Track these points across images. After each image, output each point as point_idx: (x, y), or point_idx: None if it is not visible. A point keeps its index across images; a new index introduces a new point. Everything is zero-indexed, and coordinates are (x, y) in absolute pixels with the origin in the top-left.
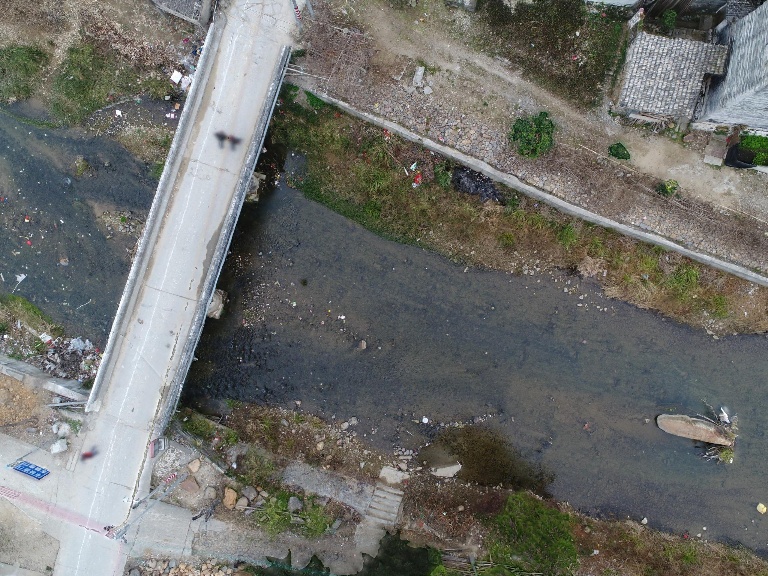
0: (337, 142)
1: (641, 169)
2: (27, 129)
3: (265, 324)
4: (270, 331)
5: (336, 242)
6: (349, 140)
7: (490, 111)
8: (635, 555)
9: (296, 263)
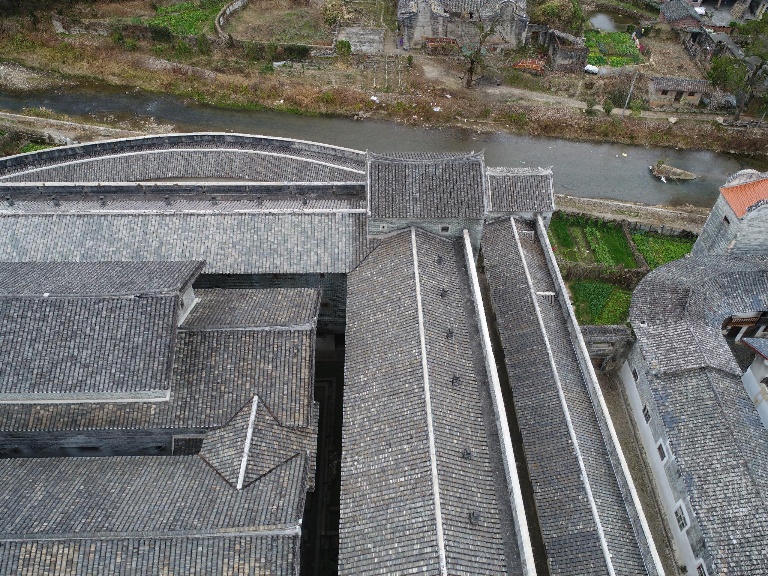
0: None
1: None
2: None
3: None
4: None
5: None
6: None
7: None
8: (679, 136)
9: None
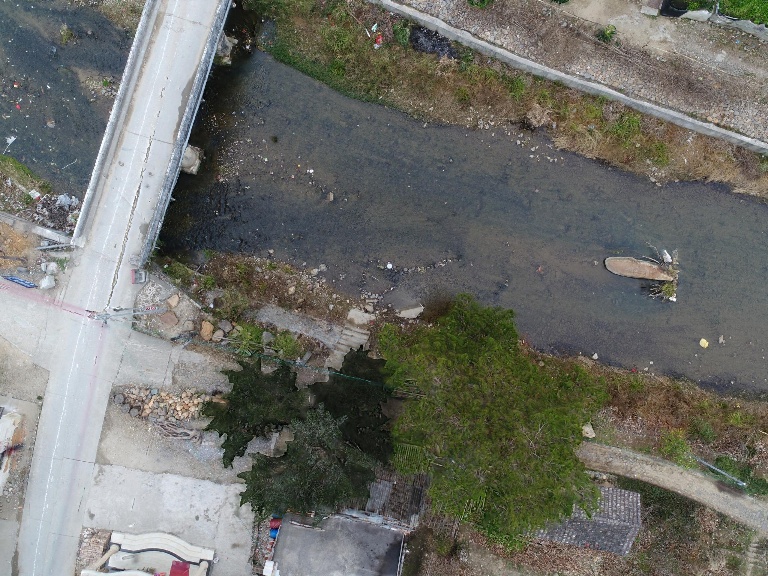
0: (302, 2)
1: None
2: (15, 2)
3: (239, 179)
4: (244, 186)
5: (304, 102)
6: (314, 4)
7: None
8: None
9: (267, 122)
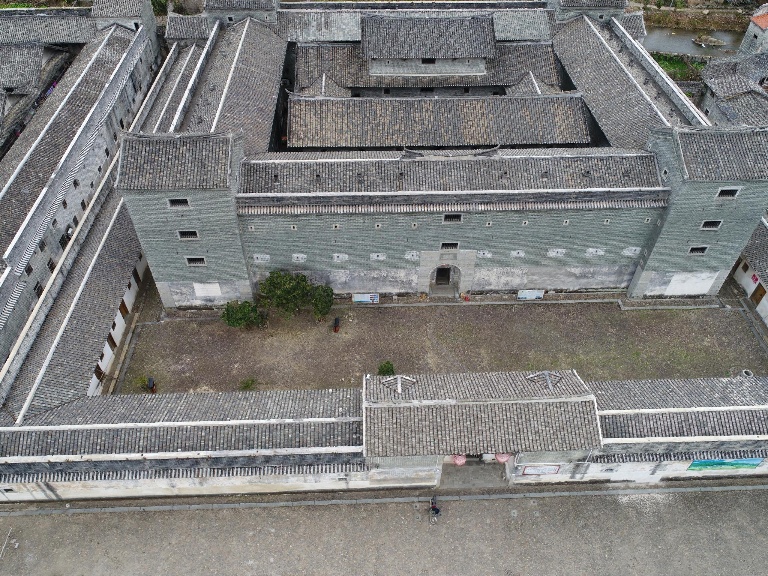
0: None
1: None
2: None
3: None
4: None
5: None
6: None
7: None
8: None
9: None
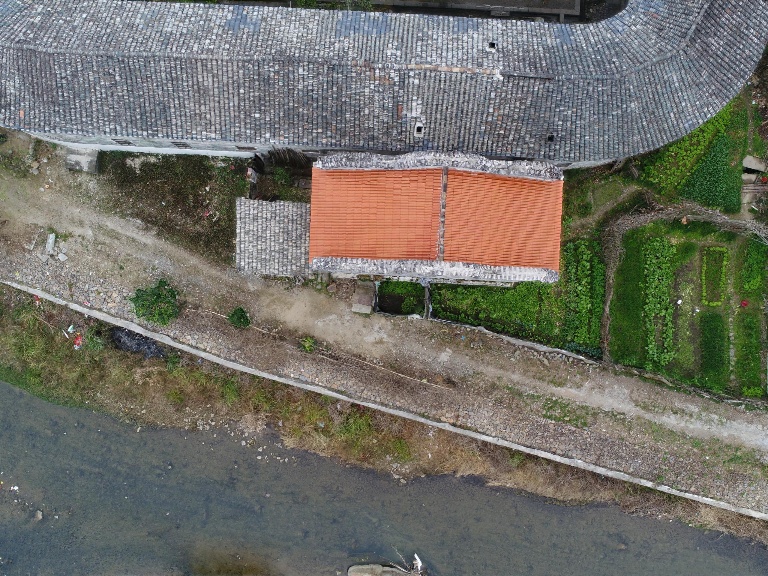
0: None
1: (287, 323)
2: None
3: None
4: None
5: (4, 410)
6: (4, 306)
7: (128, 274)
8: None
9: None
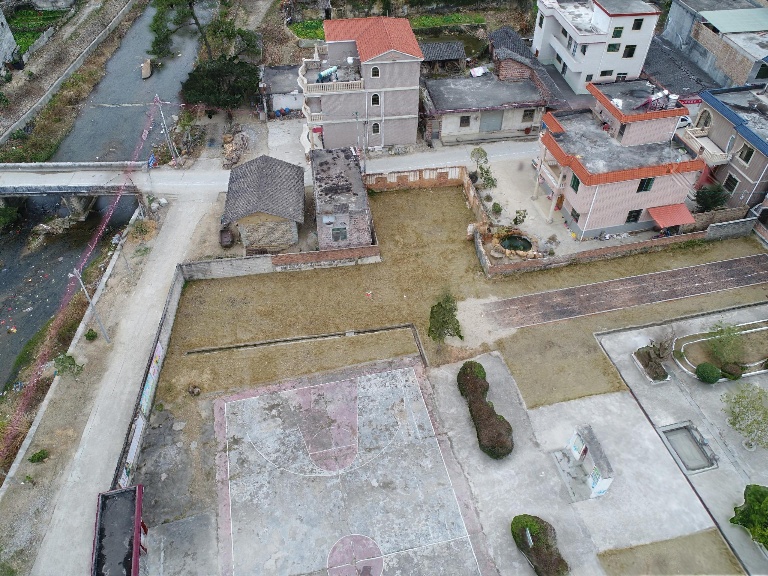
0: None
1: None
2: None
3: None
4: None
5: None
6: None
7: None
8: None
9: None
